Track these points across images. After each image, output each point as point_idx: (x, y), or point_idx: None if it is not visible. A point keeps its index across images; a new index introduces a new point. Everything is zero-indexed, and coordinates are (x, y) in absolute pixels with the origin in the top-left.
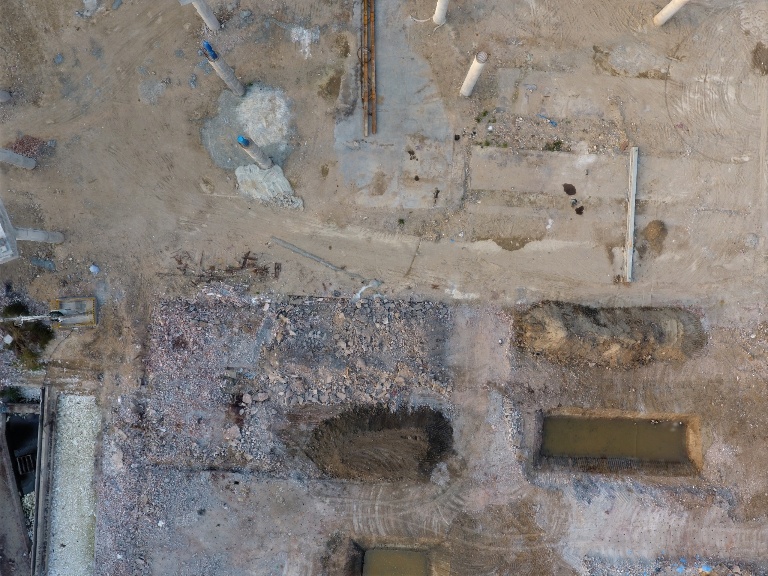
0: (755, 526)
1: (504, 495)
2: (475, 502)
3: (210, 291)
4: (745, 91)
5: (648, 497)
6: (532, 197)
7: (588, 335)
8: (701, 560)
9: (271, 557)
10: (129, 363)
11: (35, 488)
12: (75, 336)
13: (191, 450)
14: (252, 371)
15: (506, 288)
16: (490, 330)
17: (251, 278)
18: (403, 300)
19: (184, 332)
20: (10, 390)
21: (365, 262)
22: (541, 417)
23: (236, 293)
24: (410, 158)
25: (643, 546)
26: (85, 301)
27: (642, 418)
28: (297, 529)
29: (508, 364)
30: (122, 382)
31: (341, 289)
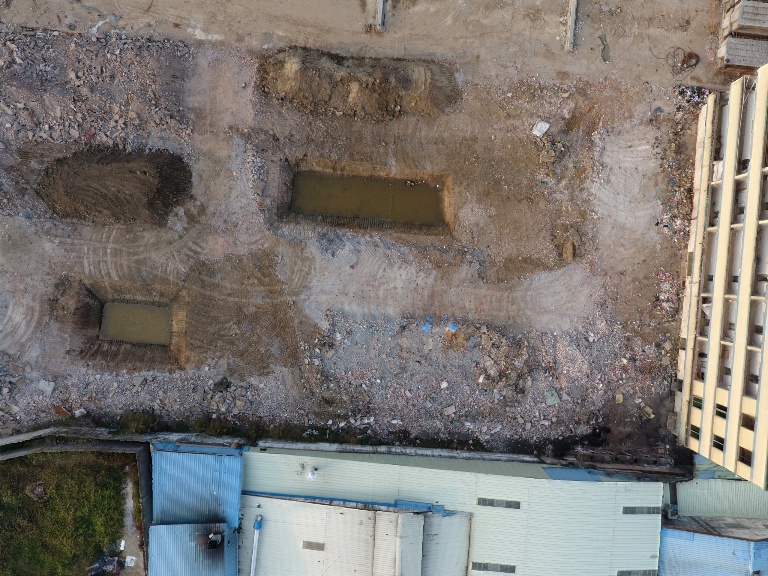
0: (506, 288)
1: (244, 244)
2: (213, 250)
3: None
4: None
5: (395, 253)
6: None
7: (324, 70)
8: (448, 320)
9: None
10: None
11: None
12: None
13: None
14: None
15: (252, 31)
16: (234, 73)
17: None
18: (142, 37)
19: None
20: None
21: None
22: (289, 169)
23: None
24: None
25: (389, 303)
26: None
27: (397, 178)
28: (24, 269)
29: (251, 108)
30: None
31: (77, 23)
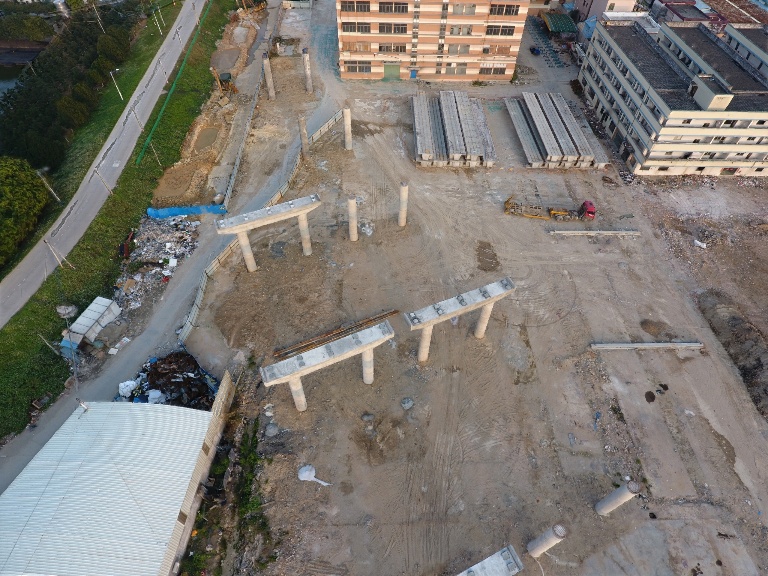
0: None
1: None
2: None
3: None
4: (517, 275)
5: None
6: (674, 431)
7: None
8: None
9: None
10: None
11: None
12: None
13: None
14: None
15: None
16: None
17: None
18: None
19: None
20: None
21: None
22: None
23: None
24: (701, 574)
25: None
26: None
27: None
28: None
29: None
30: None
31: None
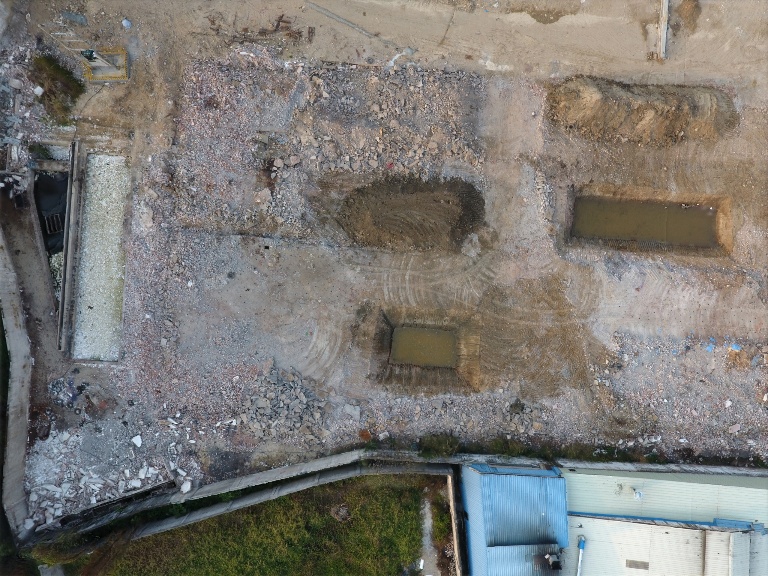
0: None
1: (535, 269)
2: (506, 275)
3: (243, 50)
4: None
5: (679, 275)
6: None
7: (623, 99)
8: (730, 340)
9: (301, 323)
10: (160, 121)
11: (64, 243)
12: (106, 91)
13: (222, 211)
14: (284, 136)
15: (540, 61)
16: (523, 102)
17: (284, 41)
18: (437, 69)
19: (216, 91)
20: (39, 147)
21: (399, 30)
22: (572, 195)
23: (269, 54)
24: None
25: (673, 324)
26: (117, 56)
27: (673, 201)
28: (327, 296)
29: (541, 136)
30: (153, 141)
31: (375, 56)
